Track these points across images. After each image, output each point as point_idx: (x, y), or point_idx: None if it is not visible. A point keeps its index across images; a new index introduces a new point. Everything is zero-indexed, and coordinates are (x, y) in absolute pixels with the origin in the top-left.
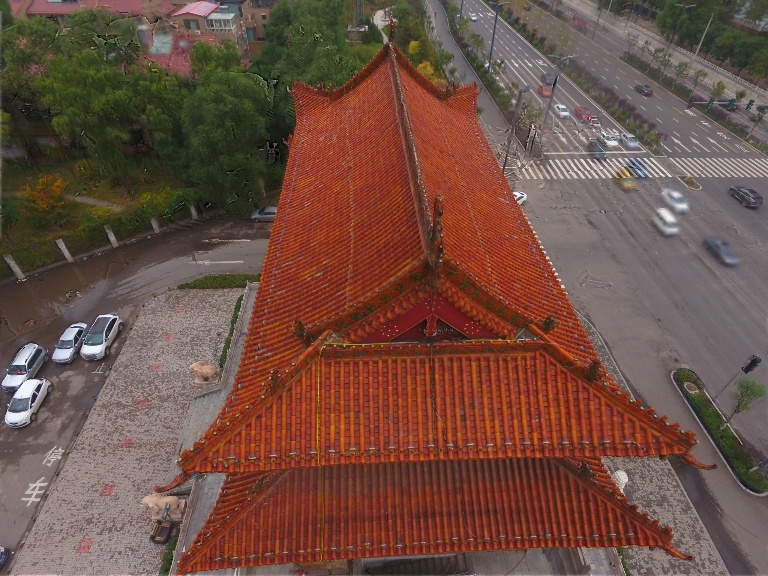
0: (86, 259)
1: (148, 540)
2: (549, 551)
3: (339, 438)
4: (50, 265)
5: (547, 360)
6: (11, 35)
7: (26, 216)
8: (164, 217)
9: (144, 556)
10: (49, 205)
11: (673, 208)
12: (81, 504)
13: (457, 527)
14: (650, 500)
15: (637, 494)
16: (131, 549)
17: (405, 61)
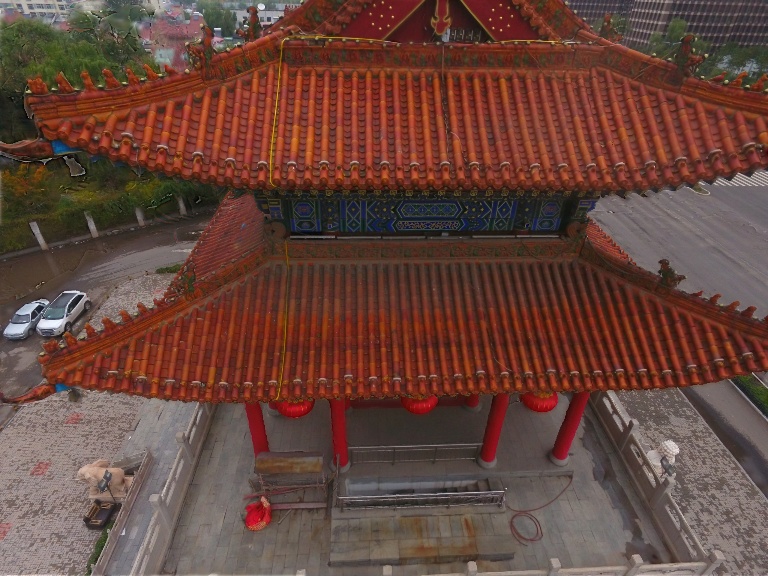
0: (61, 247)
1: (81, 525)
2: (603, 478)
3: (304, 154)
4: (21, 251)
5: (608, 77)
6: (11, 33)
7: (5, 210)
8: (150, 209)
9: (73, 544)
10: (28, 191)
11: (684, 209)
12: (5, 484)
13: (483, 361)
14: (706, 483)
15: (689, 476)
16: (58, 536)
17: None
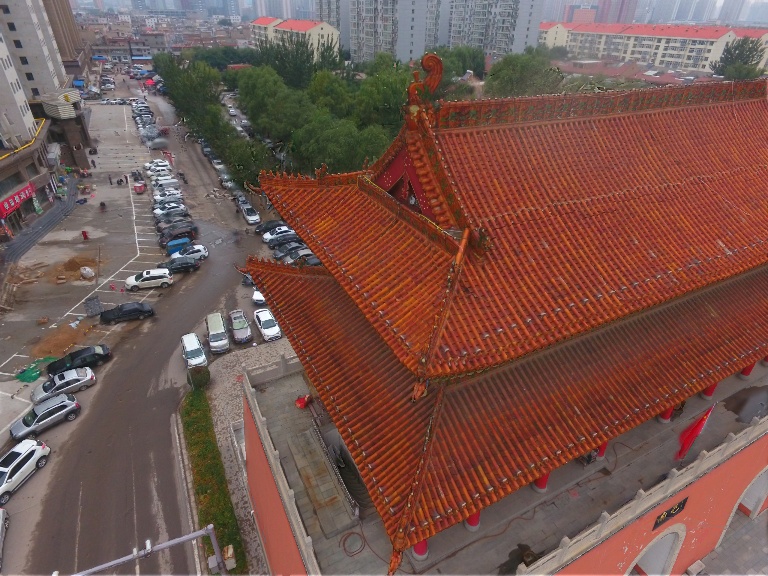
0: None
1: None
2: None
3: None
4: None
5: None
6: None
7: None
8: None
9: None
10: None
11: None
12: None
13: None
14: None
15: None
16: None
17: None
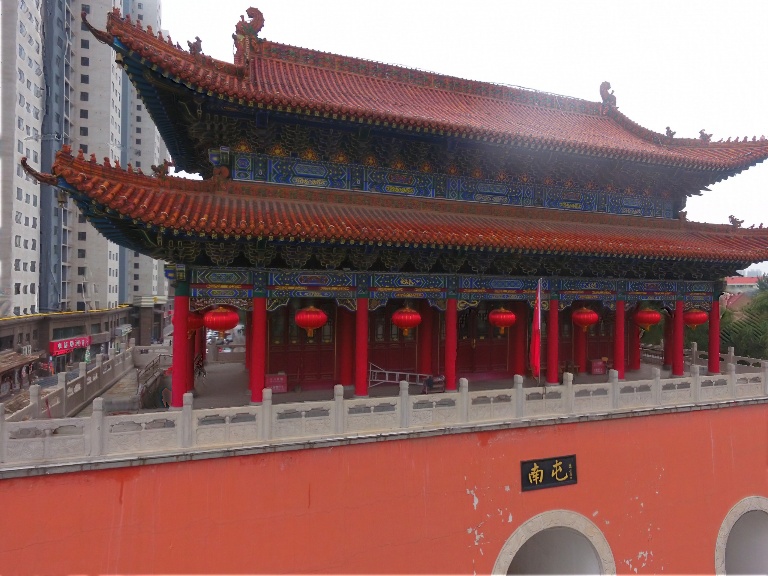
0: None
1: None
2: None
3: None
4: None
5: None
6: None
7: None
8: None
9: None
10: None
11: None
12: None
13: None
14: None
15: None
16: None
17: (621, 117)
